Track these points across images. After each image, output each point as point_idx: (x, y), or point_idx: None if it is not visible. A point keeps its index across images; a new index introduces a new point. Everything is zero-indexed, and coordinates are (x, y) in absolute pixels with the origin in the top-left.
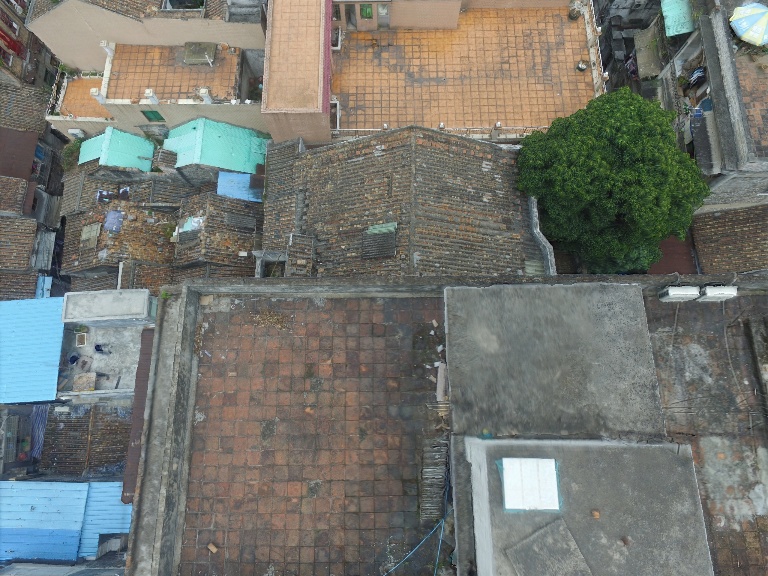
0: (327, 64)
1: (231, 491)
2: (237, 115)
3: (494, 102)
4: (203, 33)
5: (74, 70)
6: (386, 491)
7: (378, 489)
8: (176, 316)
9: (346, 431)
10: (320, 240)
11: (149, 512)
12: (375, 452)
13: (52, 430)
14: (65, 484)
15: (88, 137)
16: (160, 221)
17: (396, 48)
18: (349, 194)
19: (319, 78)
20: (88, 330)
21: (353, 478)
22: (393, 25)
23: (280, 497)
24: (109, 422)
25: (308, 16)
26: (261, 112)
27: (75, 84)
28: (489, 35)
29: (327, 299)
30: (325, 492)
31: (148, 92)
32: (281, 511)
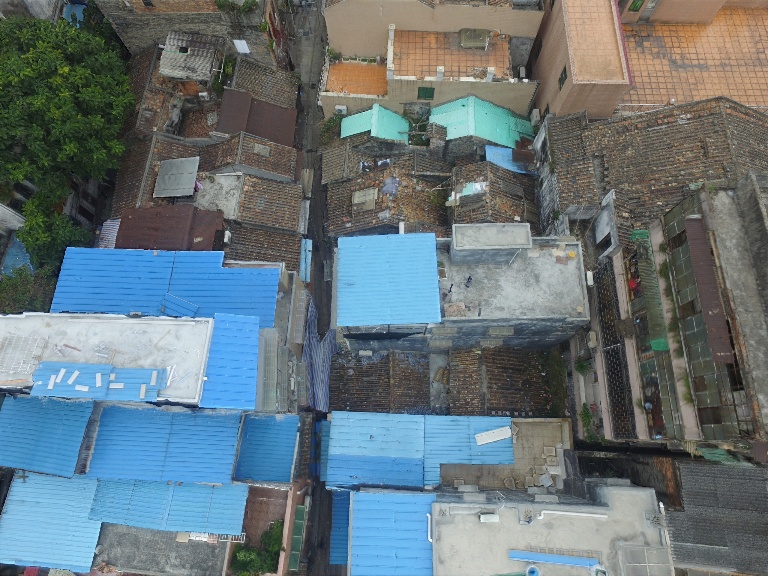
0: (624, 44)
1: None
2: (506, 94)
3: (758, 86)
4: (484, 20)
5: (337, 55)
6: None
7: None
8: (721, 207)
9: None
10: (630, 198)
11: (756, 367)
12: None
13: (340, 376)
14: (401, 416)
15: None
16: (436, 187)
17: (656, 38)
18: (656, 157)
19: (621, 55)
20: None
21: None
22: (653, 18)
23: None
24: (404, 368)
25: (598, 4)
26: (573, 82)
27: (336, 67)
28: (741, 29)
29: None
30: None
31: (441, 68)
32: None
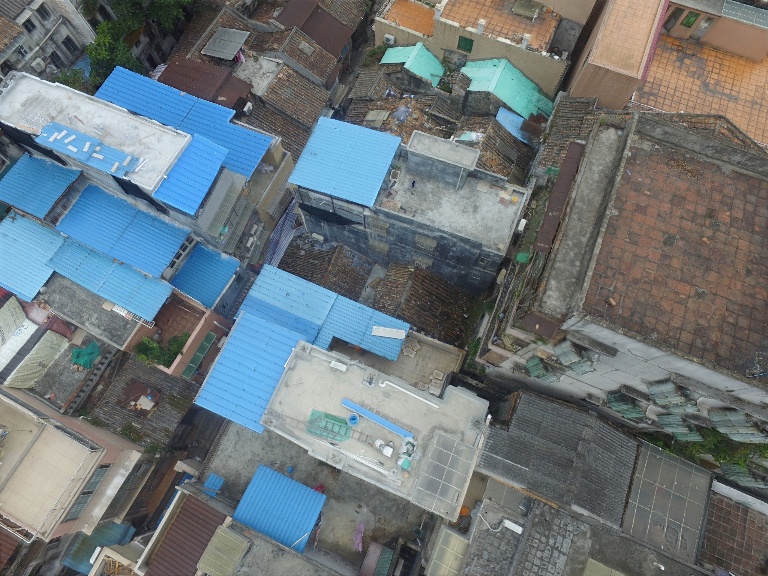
0: (654, 45)
1: (632, 270)
2: (536, 67)
3: None
4: None
5: None
6: (762, 319)
7: (755, 315)
8: (605, 140)
9: (735, 265)
10: None
11: (562, 260)
12: (757, 289)
13: (292, 253)
14: (319, 287)
15: (394, 46)
16: None
17: (699, 59)
18: None
19: (645, 53)
20: (400, 171)
21: (735, 300)
22: (704, 40)
23: (671, 290)
24: (346, 263)
25: (646, 4)
26: (588, 62)
27: (401, 3)
28: None
29: (733, 170)
30: (710, 300)
31: (482, 21)
32: (670, 299)
